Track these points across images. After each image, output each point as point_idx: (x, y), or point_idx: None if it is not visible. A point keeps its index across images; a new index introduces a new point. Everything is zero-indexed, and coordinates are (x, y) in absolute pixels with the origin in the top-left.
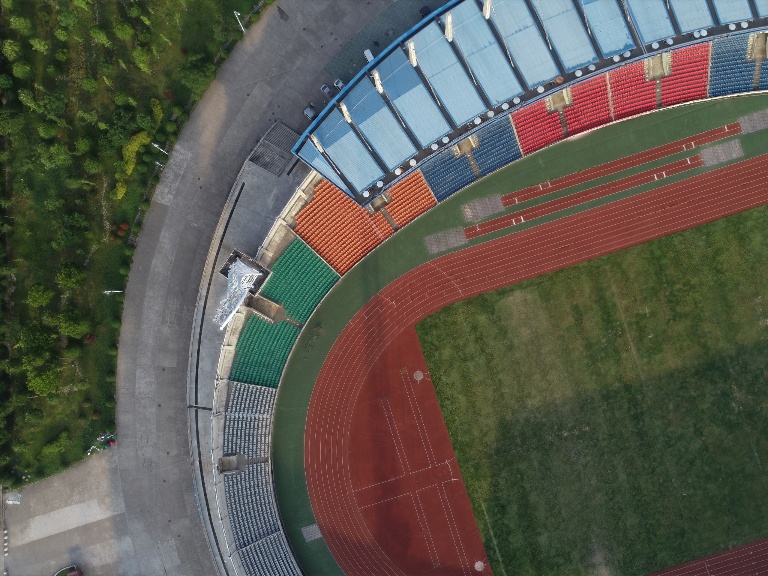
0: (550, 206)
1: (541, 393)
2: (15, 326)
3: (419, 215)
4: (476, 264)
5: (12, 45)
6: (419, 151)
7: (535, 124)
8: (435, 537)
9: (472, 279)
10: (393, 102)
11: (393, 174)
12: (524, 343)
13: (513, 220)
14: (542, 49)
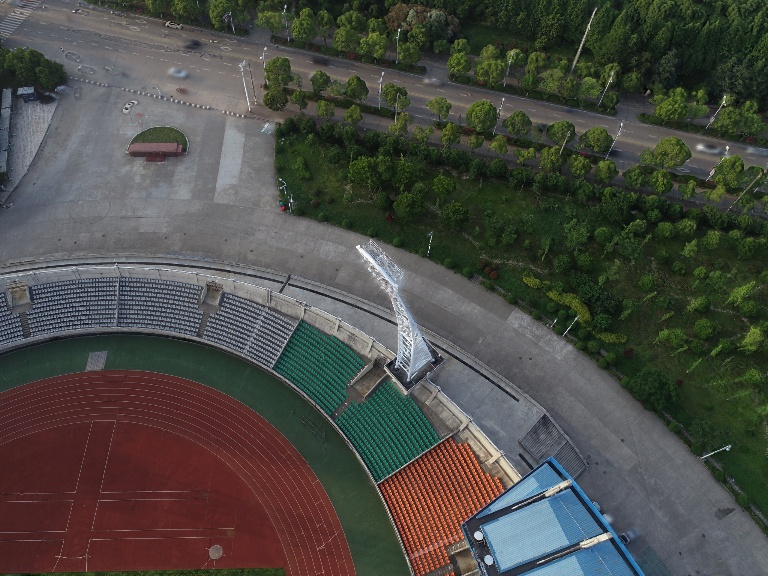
0: None
1: None
2: (421, 164)
3: None
4: None
5: (691, 227)
6: None
7: None
8: (3, 508)
9: None
10: None
11: None
12: None
13: None
14: None
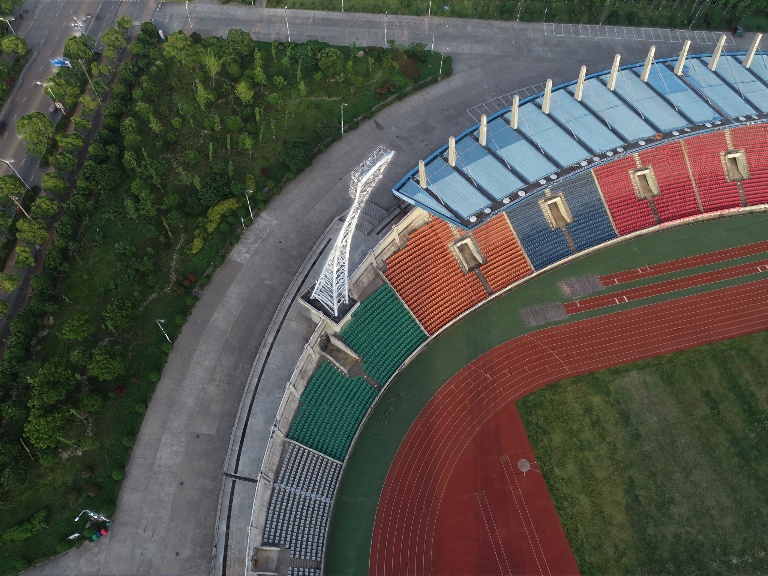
0: (653, 288)
1: (688, 499)
2: (35, 364)
3: (515, 281)
4: (581, 340)
5: (131, 121)
6: (527, 184)
7: (627, 208)
8: None
9: (578, 355)
10: (496, 152)
11: (501, 203)
12: (653, 432)
13: (616, 299)
14: (636, 118)
